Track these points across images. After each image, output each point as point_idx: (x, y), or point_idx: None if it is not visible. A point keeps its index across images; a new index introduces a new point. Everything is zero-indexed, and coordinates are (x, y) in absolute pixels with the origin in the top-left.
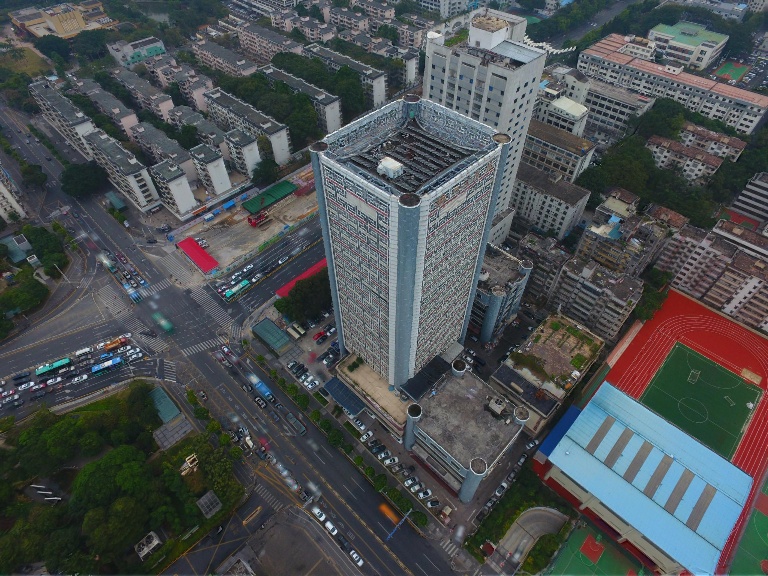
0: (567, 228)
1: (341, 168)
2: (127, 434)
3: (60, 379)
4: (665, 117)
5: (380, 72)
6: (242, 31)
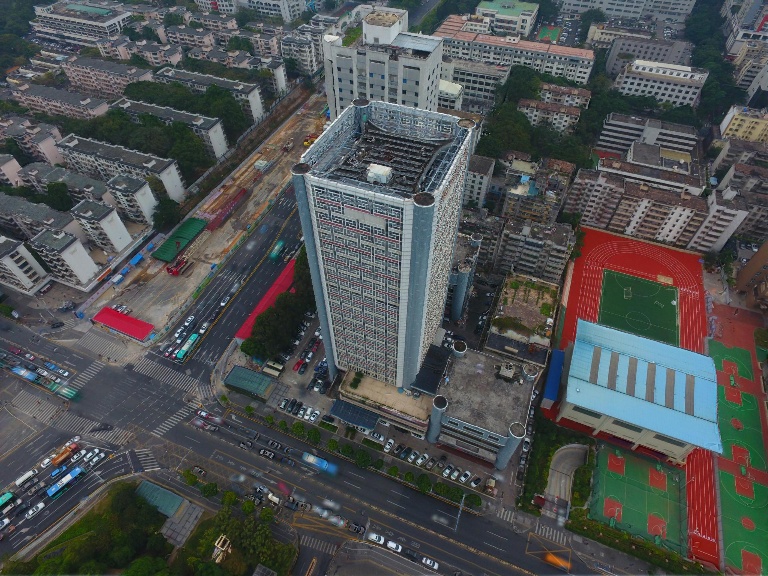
0: (484, 196)
1: (338, 185)
2: (132, 547)
3: (8, 520)
4: (525, 81)
5: (252, 85)
6: (69, 67)
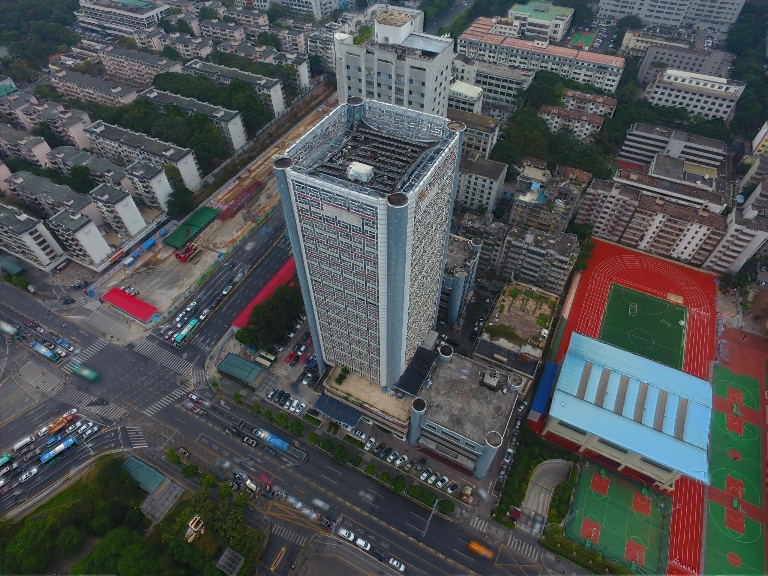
0: (494, 202)
1: (316, 181)
2: (111, 519)
3: (2, 483)
4: (548, 87)
5: (274, 80)
6: (106, 56)
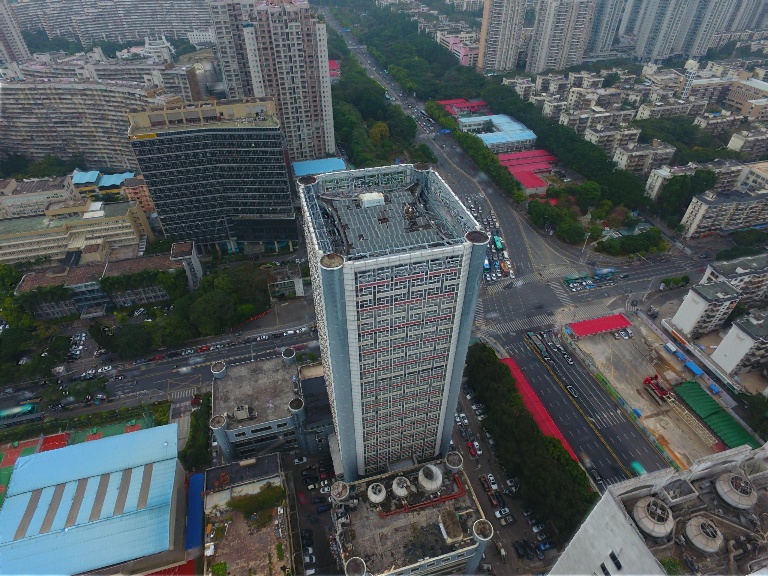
0: None
1: None
2: None
3: None
4: None
5: None
6: None
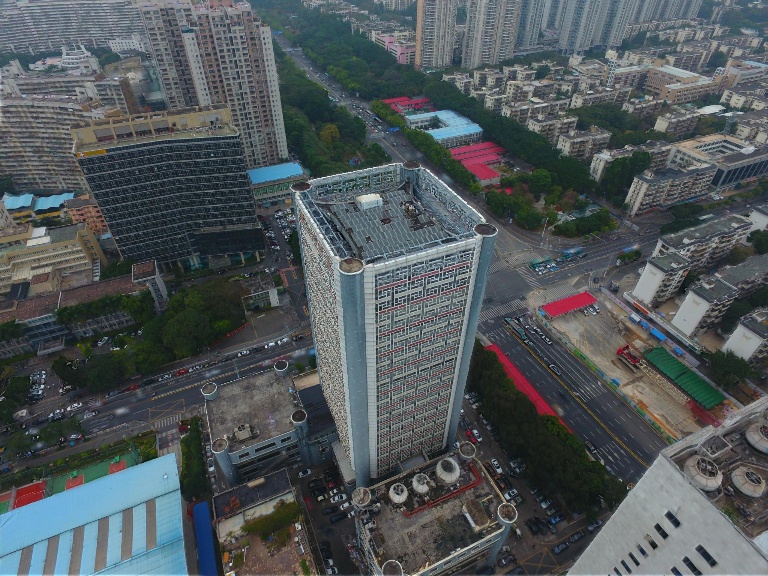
0: None
1: None
2: None
3: None
4: None
5: None
6: None
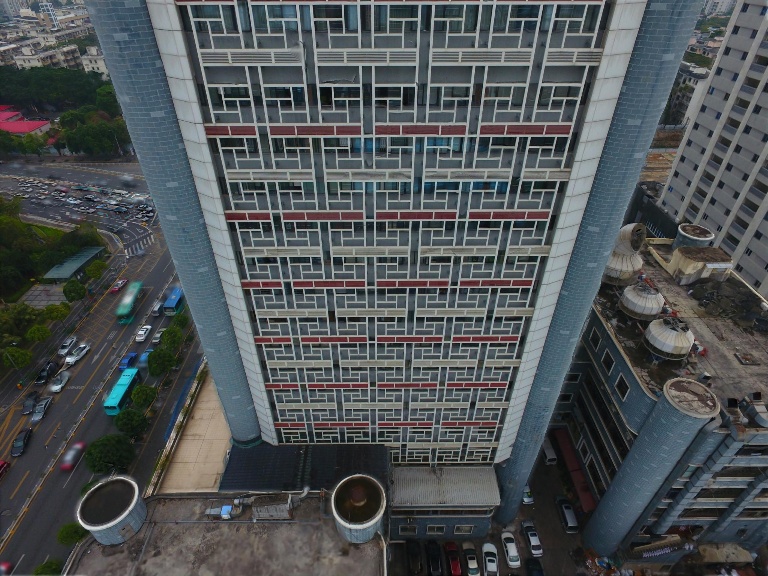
0: None
1: None
2: (4, 260)
3: (79, 202)
4: None
5: None
6: None
